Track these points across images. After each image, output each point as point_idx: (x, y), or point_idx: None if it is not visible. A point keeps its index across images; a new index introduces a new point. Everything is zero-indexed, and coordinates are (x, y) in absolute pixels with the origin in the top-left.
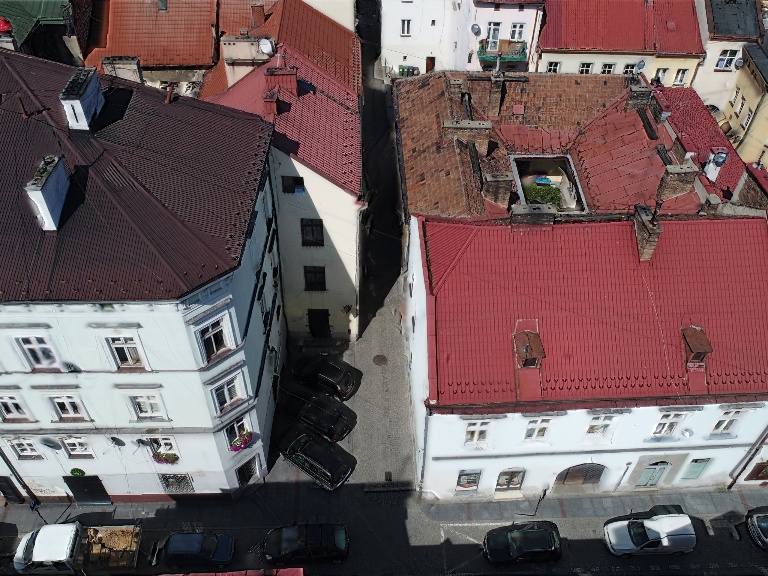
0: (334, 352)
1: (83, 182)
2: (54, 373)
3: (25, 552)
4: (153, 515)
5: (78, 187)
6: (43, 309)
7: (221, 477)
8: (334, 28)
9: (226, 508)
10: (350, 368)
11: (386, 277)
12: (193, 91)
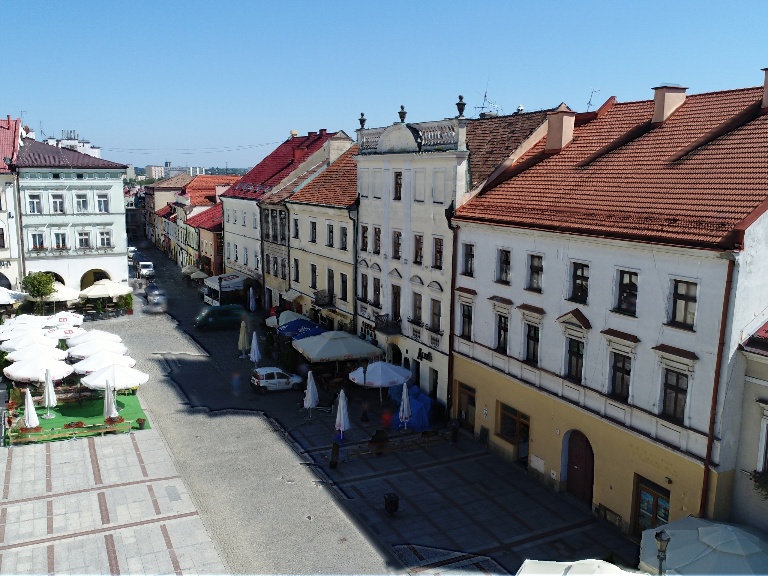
0: None
1: None
2: None
3: None
4: None
5: None
6: None
7: None
8: None
9: None
10: None
11: None
12: None
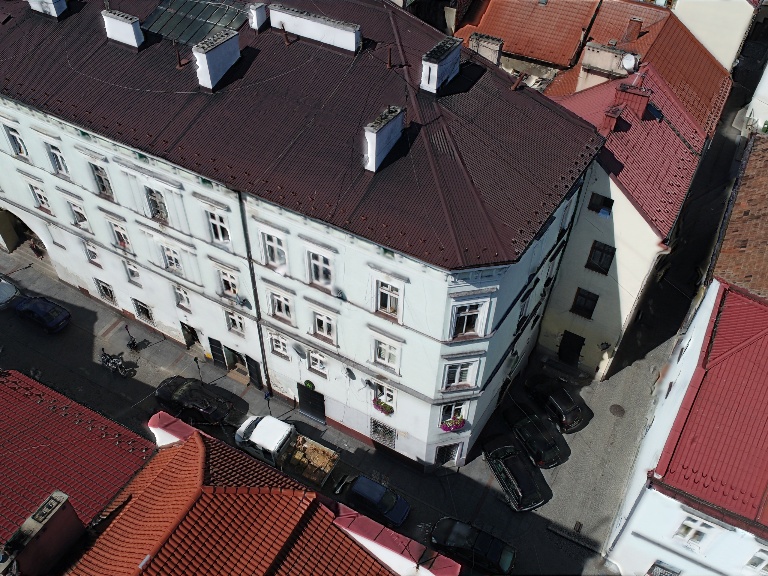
0: (574, 382)
1: (412, 138)
2: (325, 293)
3: (247, 429)
4: (353, 451)
5: (407, 141)
6: (338, 235)
7: (422, 447)
8: (709, 62)
9: (415, 477)
10: (583, 404)
11: (659, 331)
12: (540, 87)
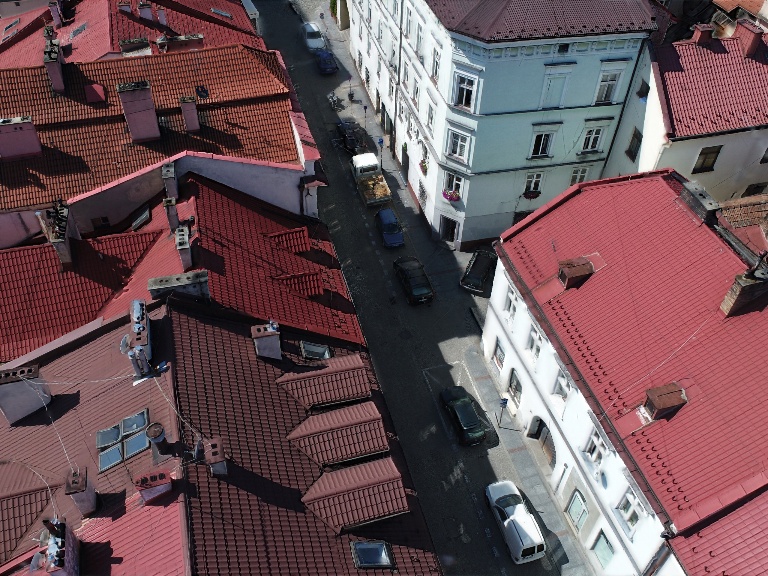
0: None
1: None
2: None
3: None
4: (407, 206)
5: None
6: None
7: None
8: None
9: (425, 237)
10: None
11: None
12: None
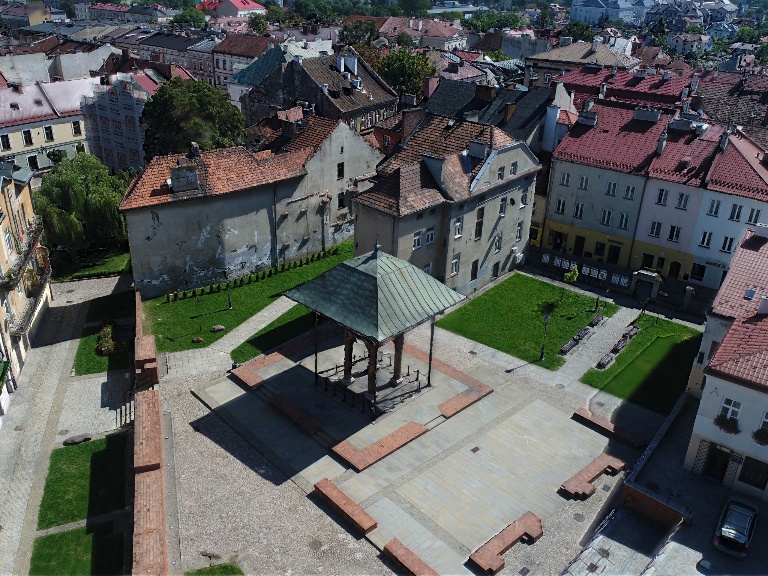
0: None
1: None
2: None
3: None
4: None
5: None
6: None
7: None
8: None
9: None
10: None
11: None
12: None
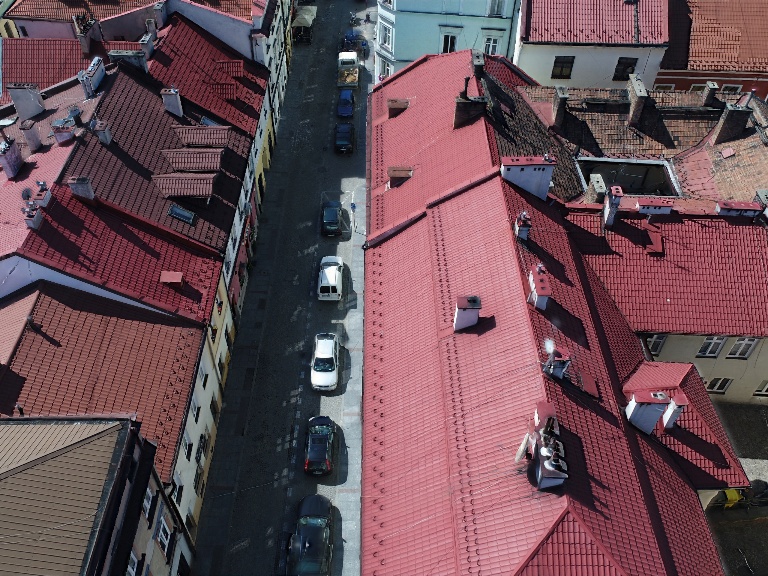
0: None
1: None
2: None
3: None
4: None
5: None
6: None
7: None
8: None
9: None
10: None
11: None
12: None
